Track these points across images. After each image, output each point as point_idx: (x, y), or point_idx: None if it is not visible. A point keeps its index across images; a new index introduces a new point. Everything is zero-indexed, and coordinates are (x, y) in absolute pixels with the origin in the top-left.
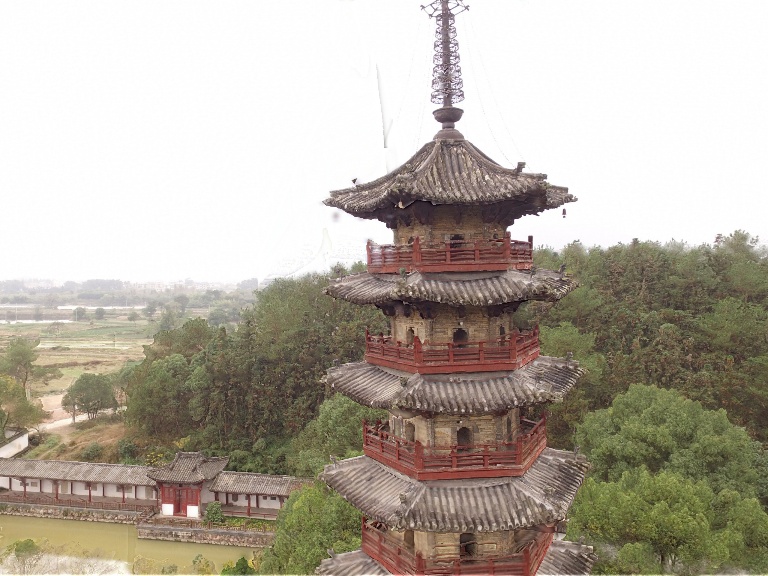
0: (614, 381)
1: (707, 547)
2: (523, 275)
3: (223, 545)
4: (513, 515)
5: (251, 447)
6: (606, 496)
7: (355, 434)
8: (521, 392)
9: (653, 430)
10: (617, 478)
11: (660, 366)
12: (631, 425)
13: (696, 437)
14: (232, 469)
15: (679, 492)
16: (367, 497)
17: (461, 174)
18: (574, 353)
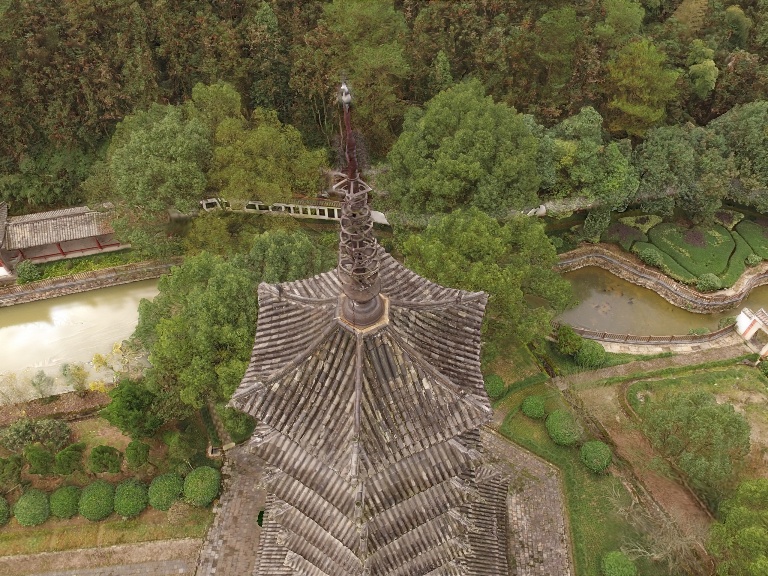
0: (417, 58)
1: (509, 295)
2: (459, 445)
3: (56, 297)
4: (440, 535)
5: (16, 165)
6: (435, 262)
7: (171, 204)
8: (451, 495)
9: (466, 166)
10: (434, 212)
11: (458, 20)
12: (447, 162)
13: (499, 159)
14: (8, 197)
15: (490, 245)
16: (323, 538)
17: (395, 379)
18: (375, 28)
